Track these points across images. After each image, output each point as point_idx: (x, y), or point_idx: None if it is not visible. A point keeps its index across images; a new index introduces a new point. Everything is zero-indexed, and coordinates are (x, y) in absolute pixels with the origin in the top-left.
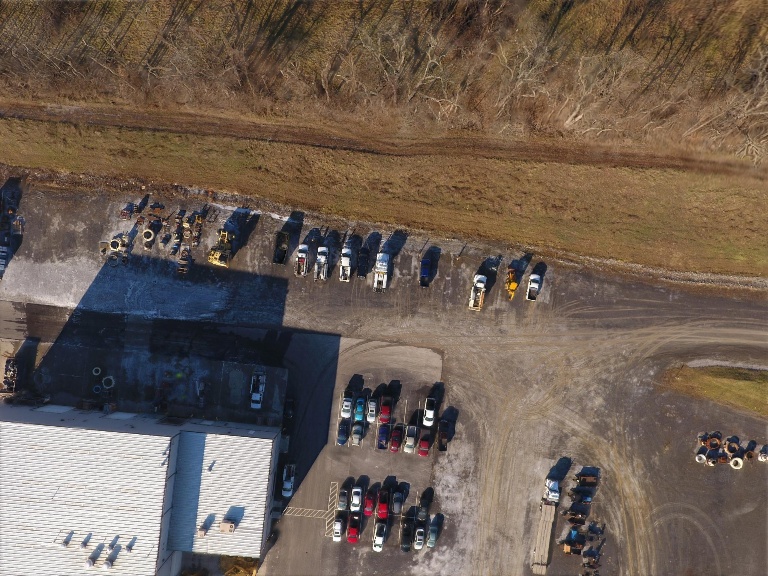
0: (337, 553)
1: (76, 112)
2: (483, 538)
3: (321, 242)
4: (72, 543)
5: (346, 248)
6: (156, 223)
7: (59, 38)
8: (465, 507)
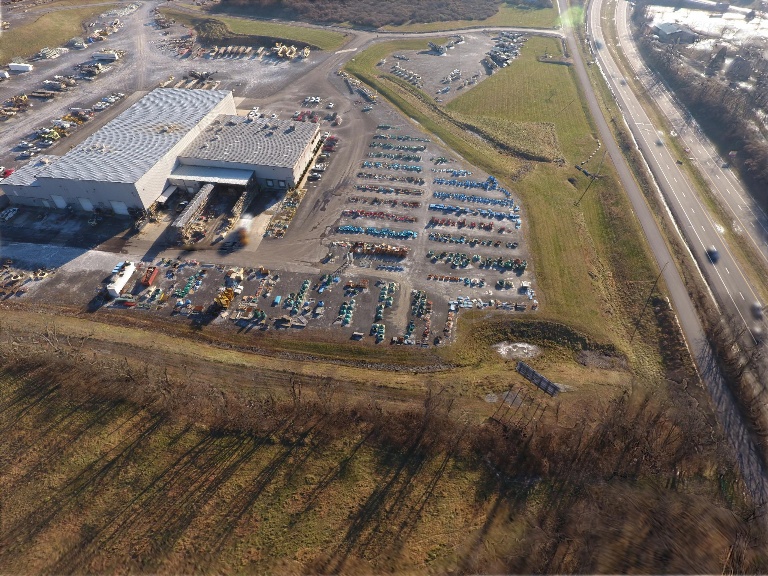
0: None
1: (6, 339)
2: None
3: None
4: None
5: None
6: None
7: None
8: None
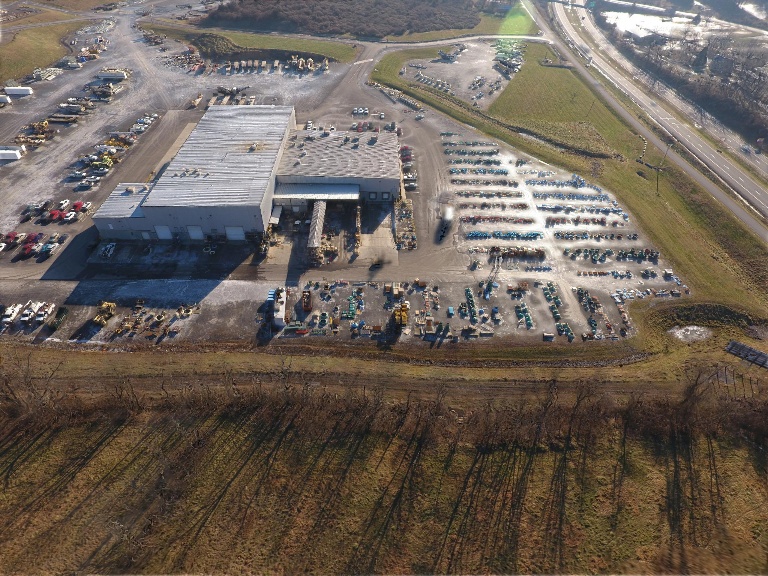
0: (93, 200)
1: None
2: (2, 209)
3: (26, 327)
4: None
5: (5, 322)
6: (154, 327)
7: None
8: (4, 218)
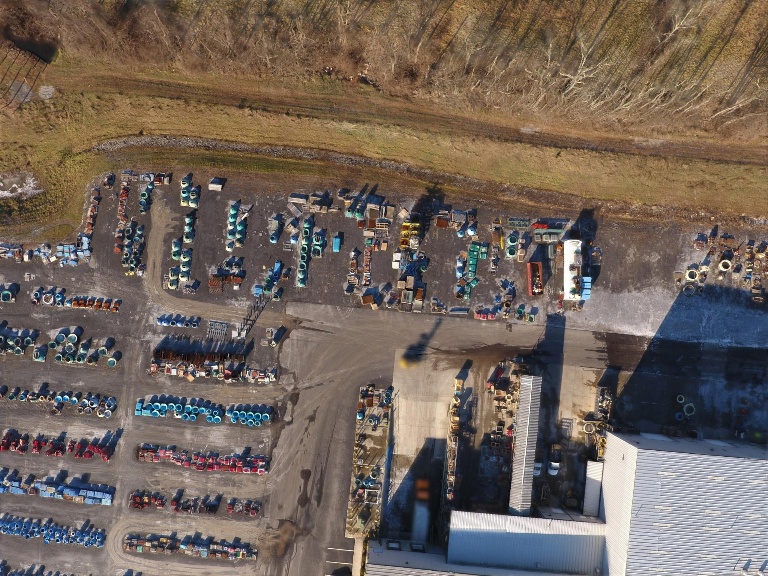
0: None
1: (662, 145)
2: None
3: None
4: (750, 570)
5: None
6: (727, 253)
7: (651, 73)
8: None
